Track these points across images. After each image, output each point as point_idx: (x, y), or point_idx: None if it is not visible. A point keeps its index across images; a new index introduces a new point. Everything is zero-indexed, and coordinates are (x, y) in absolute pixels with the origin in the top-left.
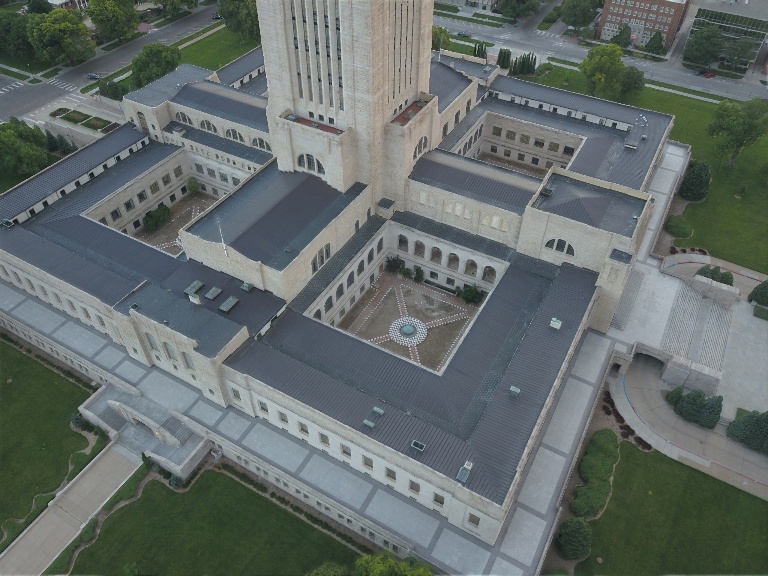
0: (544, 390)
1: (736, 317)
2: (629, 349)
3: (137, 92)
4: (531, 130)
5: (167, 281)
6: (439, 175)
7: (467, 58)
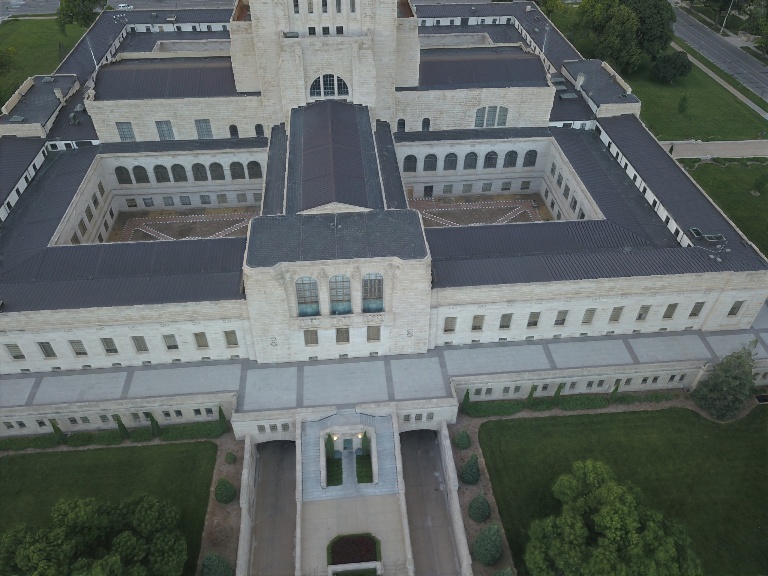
0: (461, 6)
1: None
2: None
3: (397, 254)
4: None
5: (580, 117)
6: None
7: None
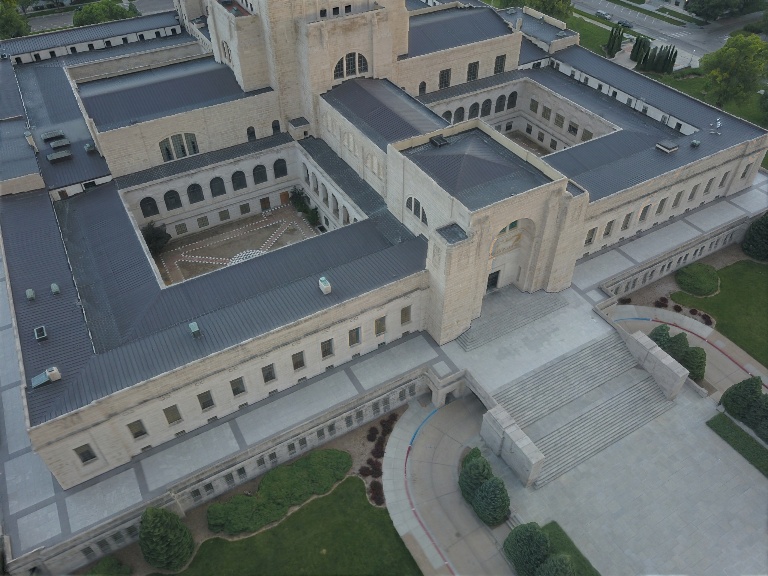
0: (227, 343)
1: (674, 413)
2: (451, 374)
3: None
4: (566, 109)
5: (48, 127)
6: (352, 100)
7: (548, 20)
